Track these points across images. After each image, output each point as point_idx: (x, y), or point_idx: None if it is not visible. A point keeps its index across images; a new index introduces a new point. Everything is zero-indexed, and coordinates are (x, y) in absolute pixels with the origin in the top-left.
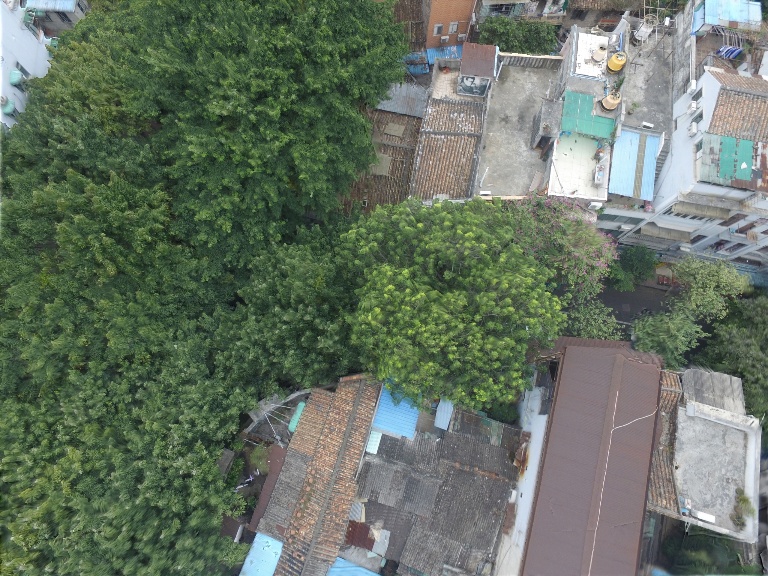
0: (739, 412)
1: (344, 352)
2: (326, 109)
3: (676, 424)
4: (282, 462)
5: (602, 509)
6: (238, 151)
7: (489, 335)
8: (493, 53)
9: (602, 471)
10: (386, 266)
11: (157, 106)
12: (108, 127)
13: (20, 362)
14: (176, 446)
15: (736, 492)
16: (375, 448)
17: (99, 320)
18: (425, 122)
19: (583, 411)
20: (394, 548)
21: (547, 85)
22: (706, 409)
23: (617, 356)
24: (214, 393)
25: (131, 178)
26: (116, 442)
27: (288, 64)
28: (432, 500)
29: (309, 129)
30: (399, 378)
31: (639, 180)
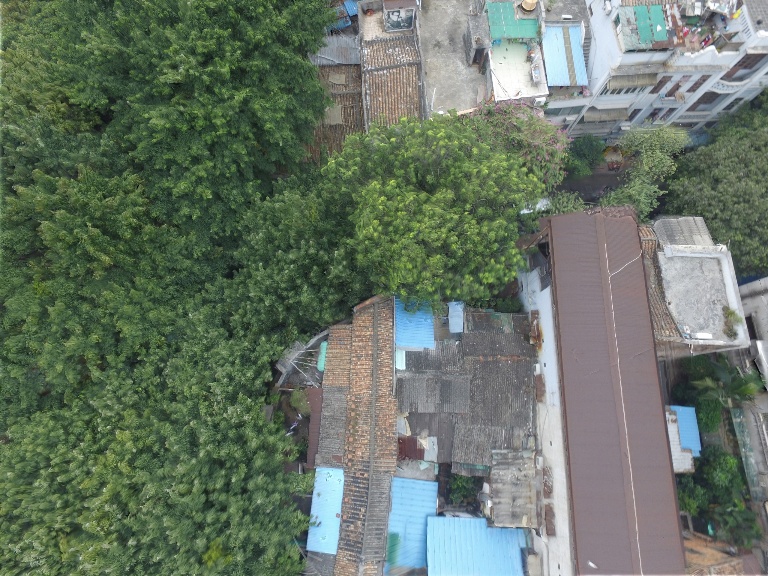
0: (708, 244)
1: (353, 277)
2: (271, 61)
3: (659, 267)
4: (321, 400)
5: (619, 345)
6: (200, 114)
7: (483, 219)
8: None
9: (610, 314)
10: None
11: (103, 94)
12: (59, 125)
13: (34, 378)
14: (220, 401)
15: (723, 310)
16: (403, 364)
17: (104, 315)
18: (365, 62)
19: (580, 269)
20: (444, 451)
21: (467, 5)
22: (681, 248)
23: (596, 214)
24: (240, 349)
25: (97, 170)
26: (158, 419)
27: (223, 25)
28: (467, 395)
29: (260, 85)
30: (413, 279)
31: (572, 69)
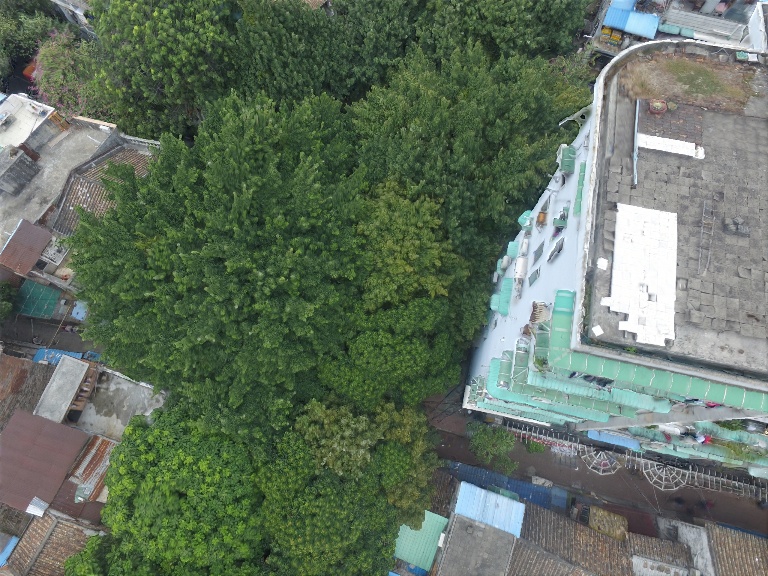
0: None
1: None
2: None
3: None
4: None
5: None
6: None
7: None
8: (6, 252)
9: None
10: (196, 6)
11: None
12: None
13: None
14: None
15: None
16: None
17: None
18: None
19: None
20: None
21: None
22: None
23: None
24: (354, 7)
25: None
26: None
27: None
28: None
29: None
30: None
31: None
